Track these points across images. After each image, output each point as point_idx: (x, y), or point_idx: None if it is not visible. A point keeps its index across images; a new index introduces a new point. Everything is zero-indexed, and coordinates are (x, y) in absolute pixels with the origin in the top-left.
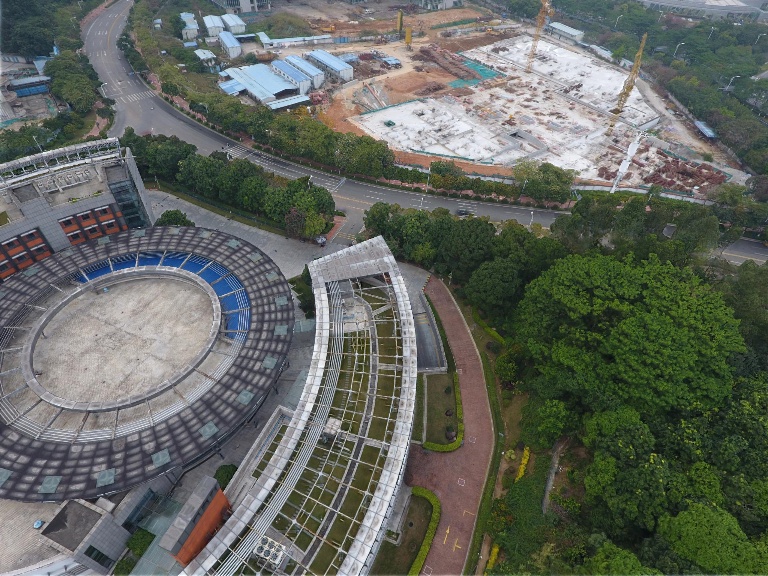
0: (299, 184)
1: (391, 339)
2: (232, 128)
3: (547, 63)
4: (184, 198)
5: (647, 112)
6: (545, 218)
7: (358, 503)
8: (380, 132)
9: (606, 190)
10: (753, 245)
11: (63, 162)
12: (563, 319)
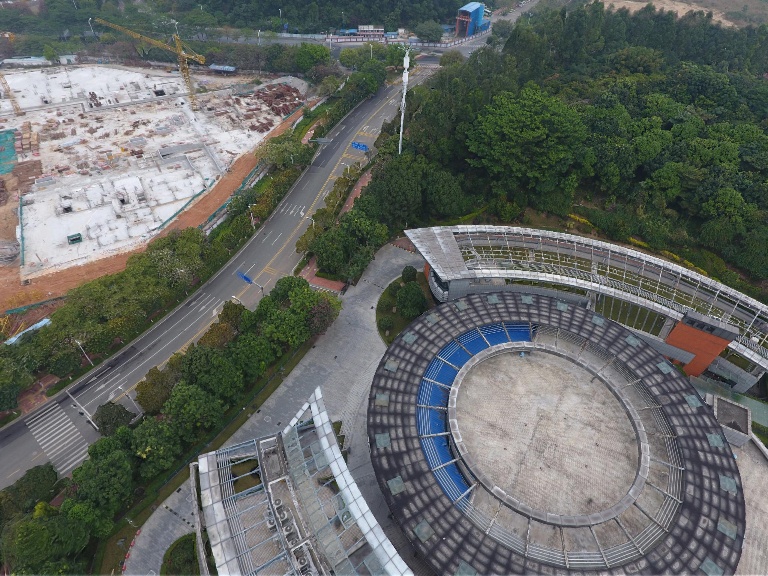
0: (268, 299)
1: (505, 252)
2: (7, 406)
3: (15, 97)
4: (182, 480)
5: (173, 81)
6: (318, 171)
7: None
8: (91, 251)
9: None
10: (368, 103)
11: (211, 575)
12: (512, 157)
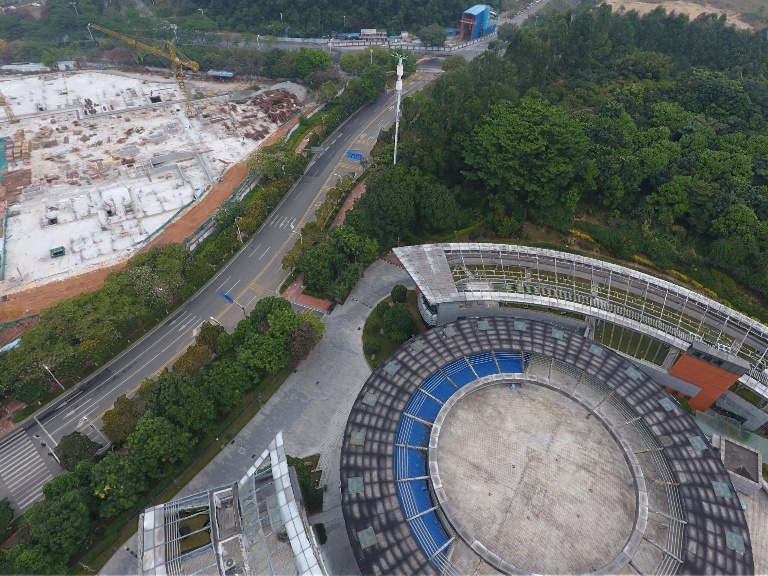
0: (246, 322)
1: None
2: None
3: (10, 104)
4: None
5: (170, 87)
6: (311, 181)
7: (640, 303)
8: (73, 265)
9: (286, 141)
10: (367, 109)
11: None
12: (509, 170)
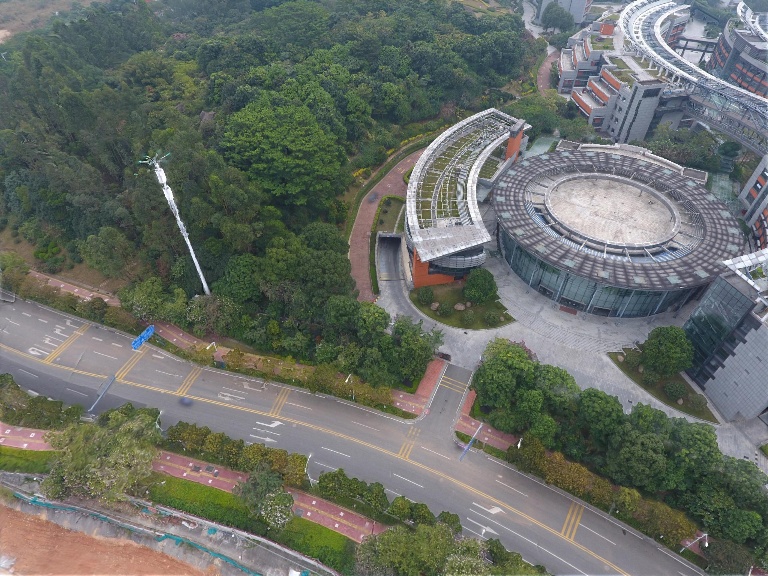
0: None
1: None
2: None
3: None
4: None
5: None
6: None
7: None
8: None
9: None
10: None
11: None
12: None
